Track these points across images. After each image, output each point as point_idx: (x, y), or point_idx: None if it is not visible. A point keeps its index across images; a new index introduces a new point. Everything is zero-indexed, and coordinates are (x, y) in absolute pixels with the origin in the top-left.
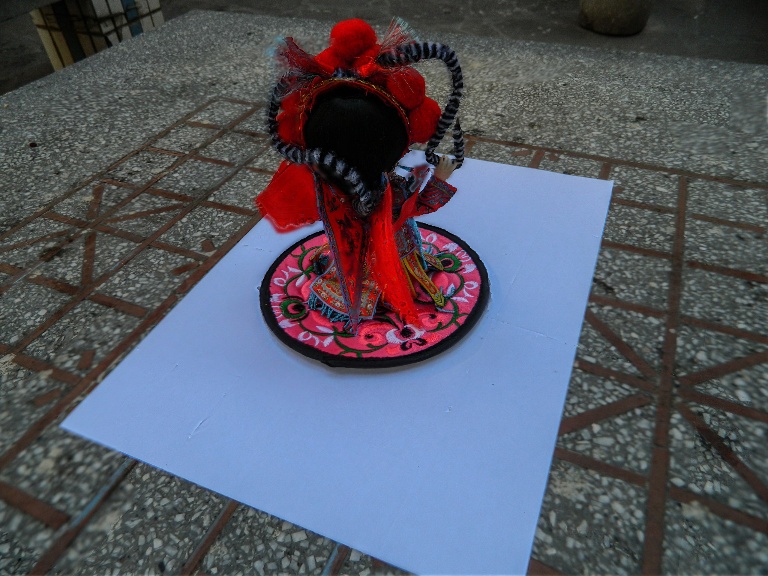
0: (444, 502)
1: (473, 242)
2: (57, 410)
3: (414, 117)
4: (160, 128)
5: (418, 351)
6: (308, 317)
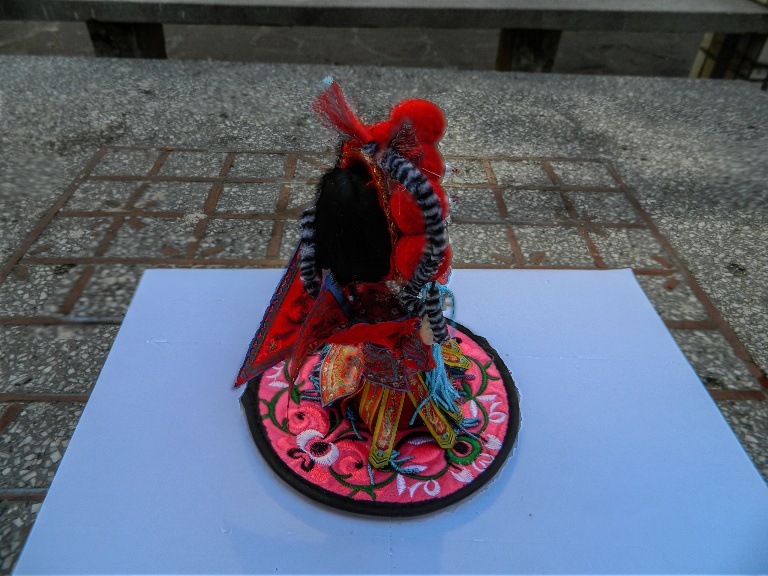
0: (100, 567)
1: (529, 467)
2: (159, 261)
3: (400, 243)
4: (521, 154)
5: (290, 467)
6: (308, 357)
